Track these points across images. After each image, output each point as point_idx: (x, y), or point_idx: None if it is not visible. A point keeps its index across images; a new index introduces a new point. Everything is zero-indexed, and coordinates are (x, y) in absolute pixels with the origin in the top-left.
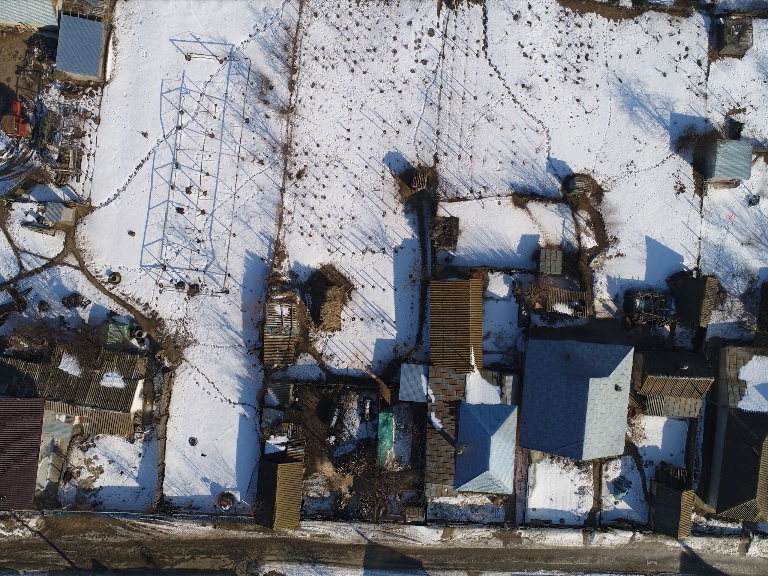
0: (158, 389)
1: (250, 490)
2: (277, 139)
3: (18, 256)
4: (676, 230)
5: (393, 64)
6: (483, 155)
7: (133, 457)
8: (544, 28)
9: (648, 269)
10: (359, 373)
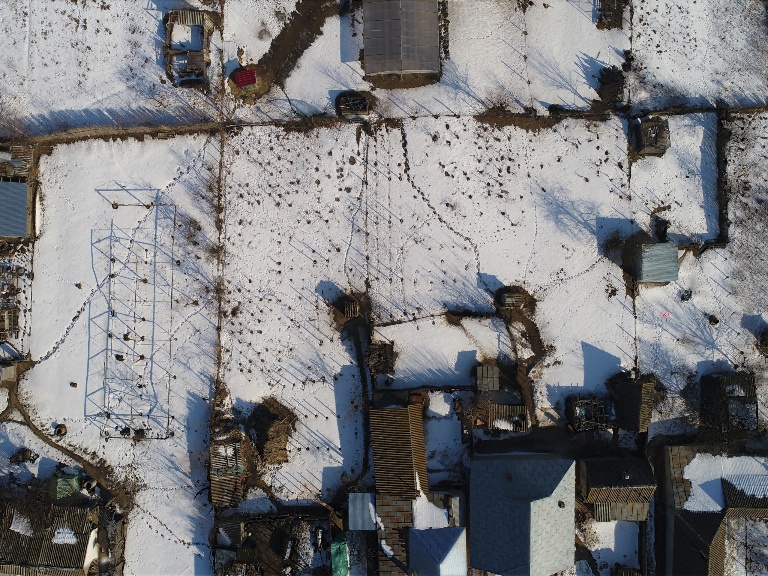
0: (112, 536)
1: None
2: (209, 279)
3: None
4: (611, 333)
5: (317, 195)
6: (414, 277)
7: None
8: (463, 146)
9: (586, 374)
10: (309, 503)
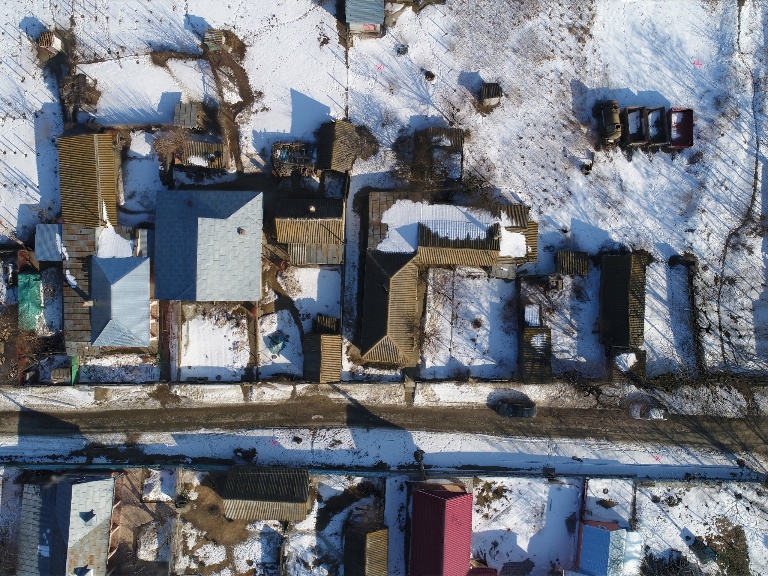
0: None
1: None
2: None
3: None
4: (321, 82)
5: None
6: (119, 15)
7: None
8: None
9: (294, 121)
10: (4, 239)
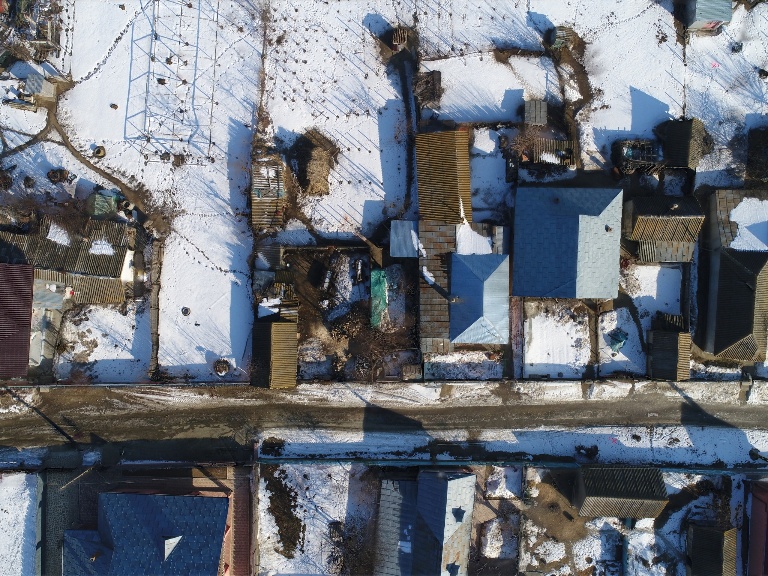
0: (148, 260)
1: (245, 356)
2: (255, 6)
3: (1, 134)
4: (660, 79)
5: None
6: (463, 12)
7: (126, 329)
8: None
9: (634, 119)
10: (349, 236)
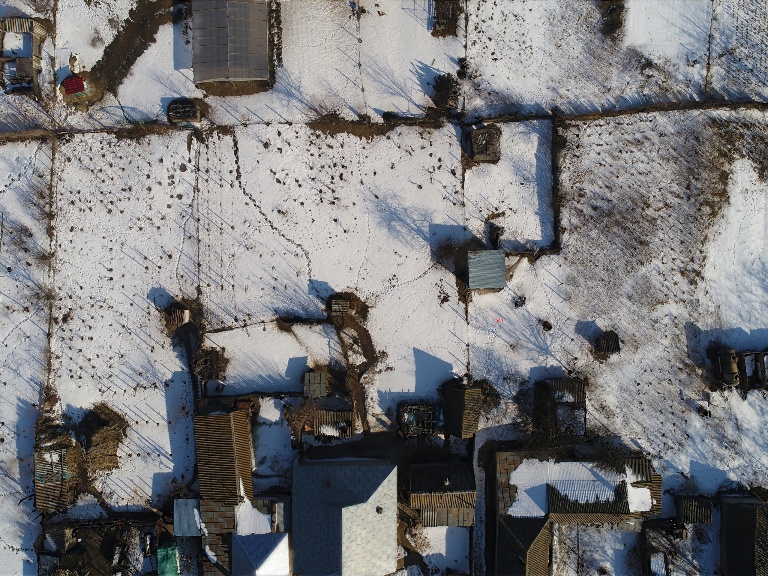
0: None
1: None
2: (40, 285)
3: None
4: (443, 339)
5: (149, 201)
6: (245, 283)
7: None
8: (295, 153)
9: (418, 380)
10: (139, 508)
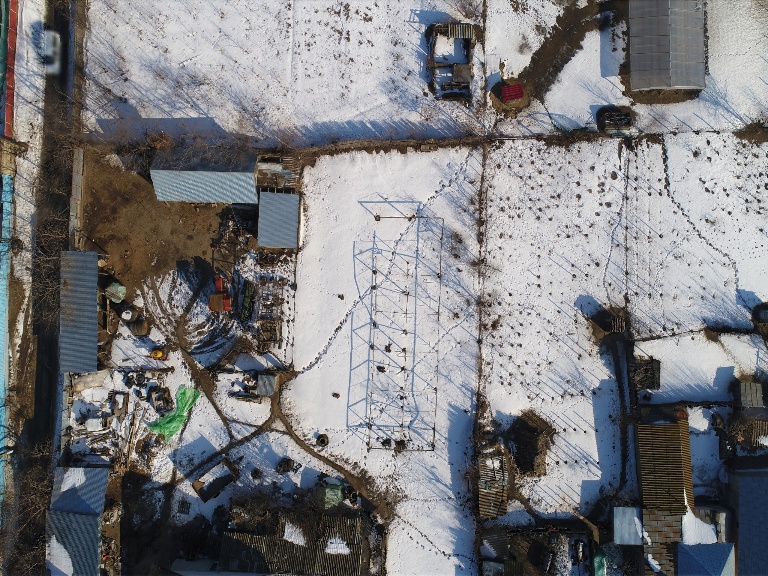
0: (373, 546)
1: None
2: (470, 291)
3: (227, 426)
4: None
5: (578, 209)
6: (673, 292)
7: None
8: (723, 162)
9: None
10: (567, 516)
